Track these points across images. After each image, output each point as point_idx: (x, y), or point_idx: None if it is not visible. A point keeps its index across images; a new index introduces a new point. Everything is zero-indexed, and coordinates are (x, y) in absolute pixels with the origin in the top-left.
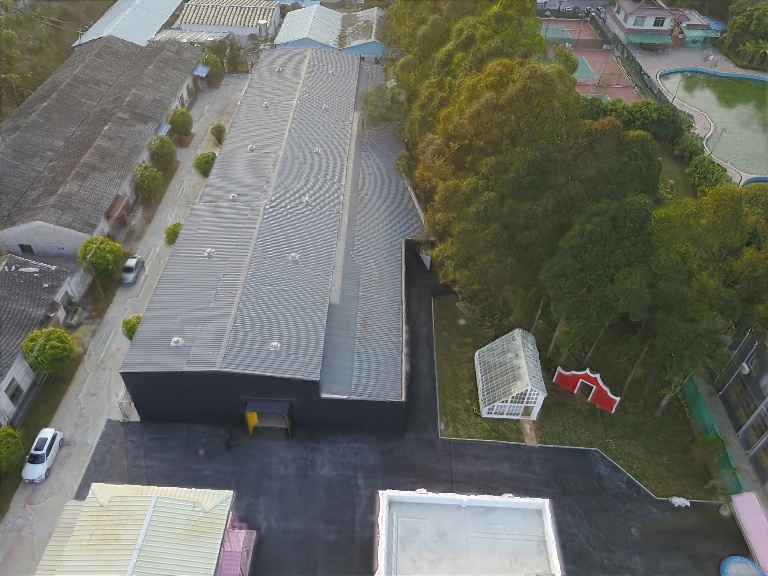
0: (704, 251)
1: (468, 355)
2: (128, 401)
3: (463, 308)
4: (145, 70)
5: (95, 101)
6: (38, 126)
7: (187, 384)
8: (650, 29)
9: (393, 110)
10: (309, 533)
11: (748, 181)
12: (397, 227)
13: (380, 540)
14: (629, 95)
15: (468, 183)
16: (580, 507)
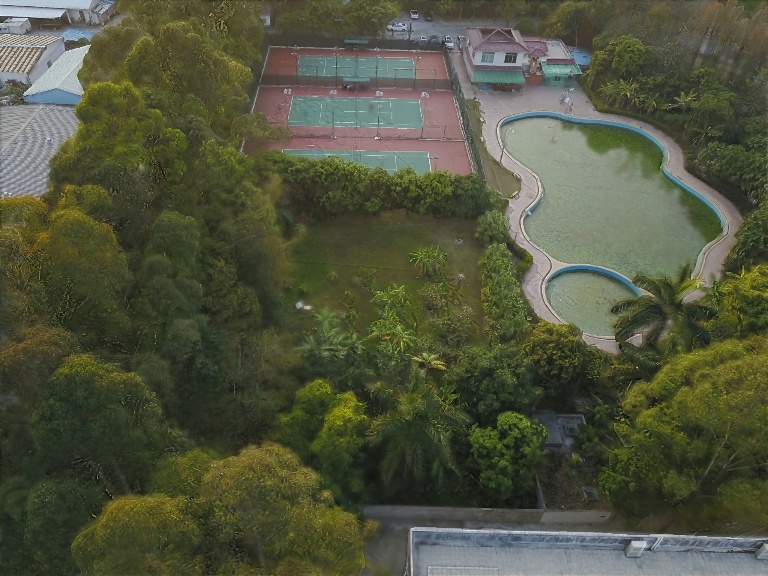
0: None
1: None
2: None
3: None
4: None
5: None
6: None
7: None
8: (501, 66)
9: None
10: None
11: (559, 272)
12: None
13: None
14: (454, 151)
15: None
16: None
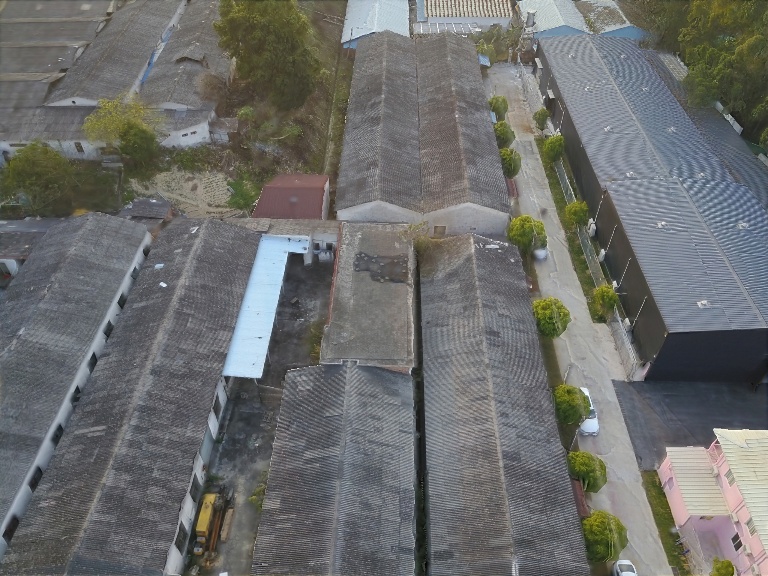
0: None
1: None
2: (641, 362)
3: None
4: (446, 61)
5: (415, 92)
6: (391, 117)
7: (722, 343)
8: None
9: (720, 89)
10: None
11: None
12: None
13: None
14: None
15: None
16: None
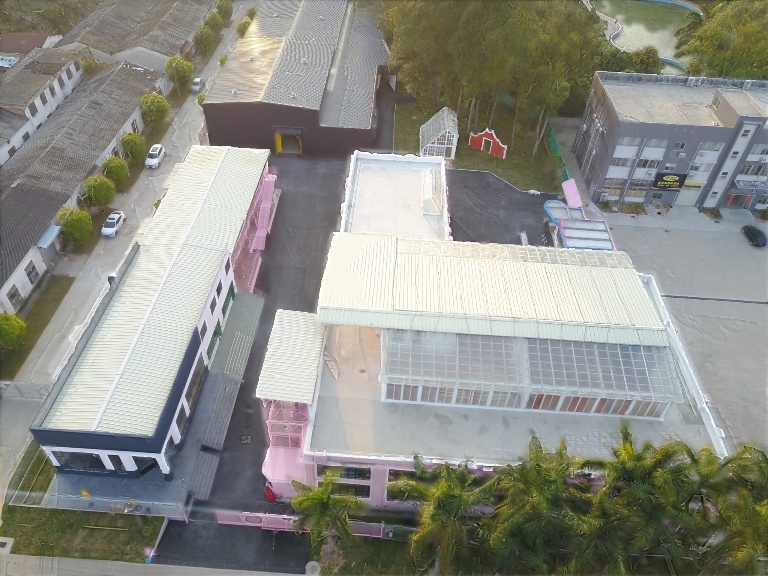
0: (530, 14)
1: (416, 132)
2: (204, 133)
3: (409, 88)
4: None
5: None
6: (128, 3)
7: (241, 114)
8: None
9: None
10: (312, 192)
11: None
12: (374, 61)
13: (350, 169)
14: None
15: (411, 2)
16: (473, 193)
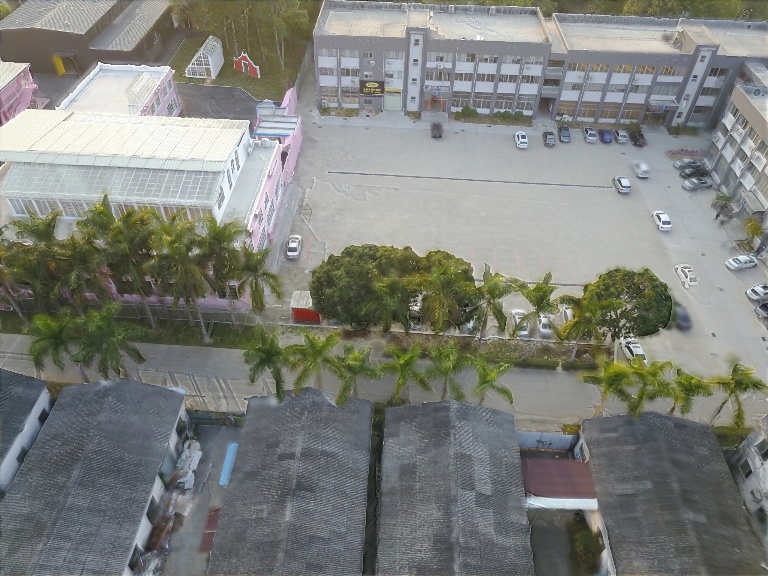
0: None
1: None
2: None
3: (175, 19)
4: None
5: None
6: None
7: (23, 40)
8: None
9: None
10: None
11: None
12: None
13: None
14: None
15: None
16: (216, 102)
